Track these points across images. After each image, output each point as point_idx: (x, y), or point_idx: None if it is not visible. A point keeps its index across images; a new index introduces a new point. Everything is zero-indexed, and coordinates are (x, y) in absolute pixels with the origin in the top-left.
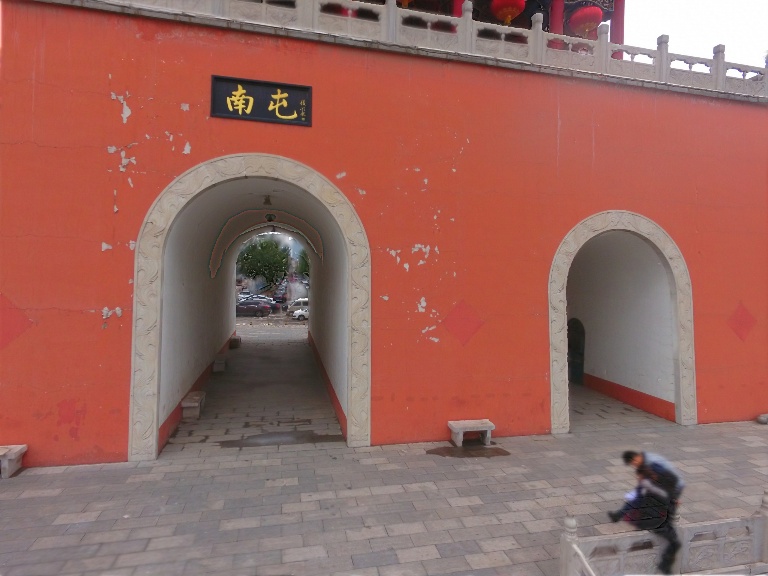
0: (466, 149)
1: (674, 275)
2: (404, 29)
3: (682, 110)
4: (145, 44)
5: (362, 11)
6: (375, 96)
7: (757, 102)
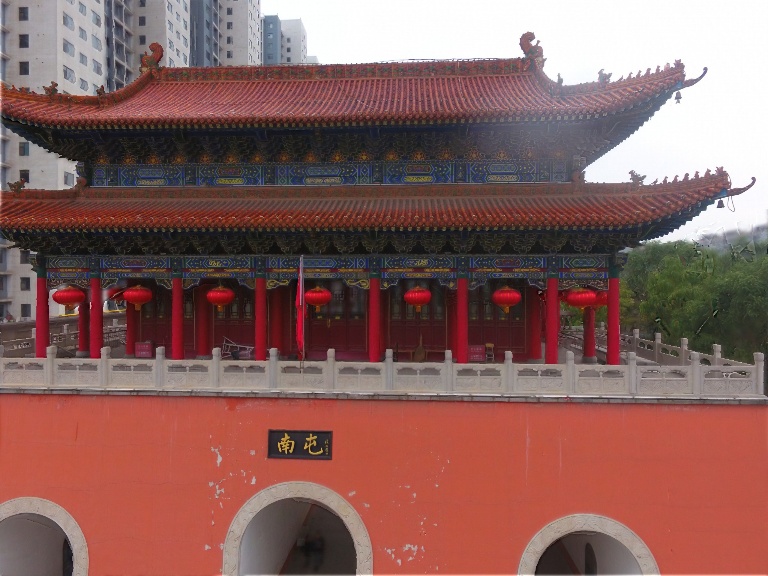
0: (447, 468)
1: (643, 572)
2: (399, 378)
3: (653, 418)
4: (230, 413)
5: (368, 369)
6: (377, 432)
7: (739, 405)
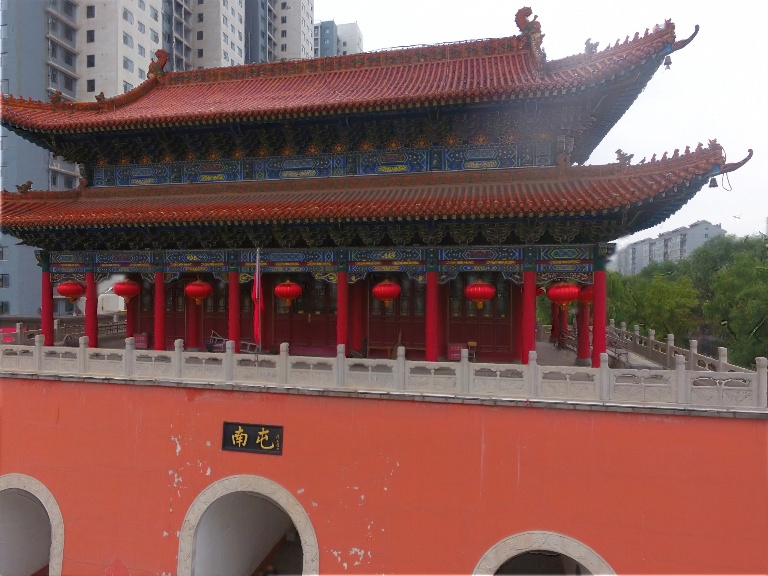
0: (396, 471)
1: None
2: (350, 374)
3: (627, 429)
4: (189, 404)
5: (320, 364)
6: (327, 430)
7: (733, 418)
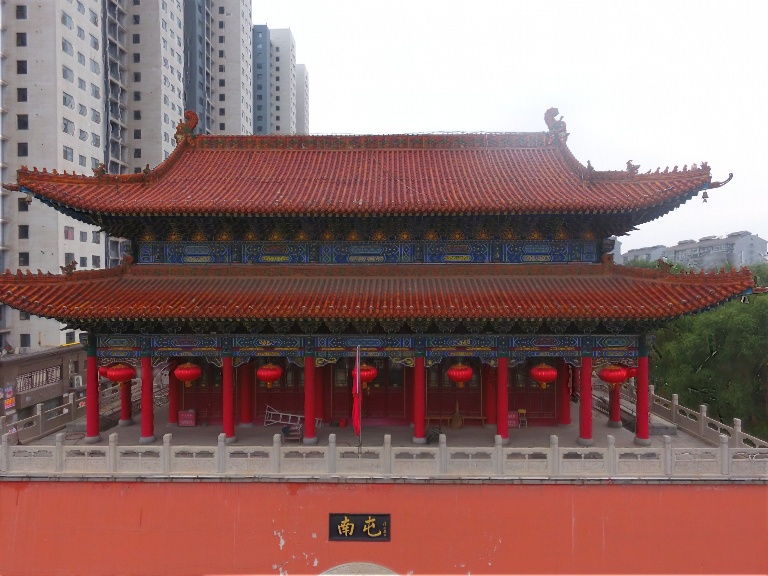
0: (499, 547)
1: None
2: (452, 462)
3: (686, 497)
4: (291, 498)
5: (423, 454)
6: (432, 514)
7: (763, 485)
